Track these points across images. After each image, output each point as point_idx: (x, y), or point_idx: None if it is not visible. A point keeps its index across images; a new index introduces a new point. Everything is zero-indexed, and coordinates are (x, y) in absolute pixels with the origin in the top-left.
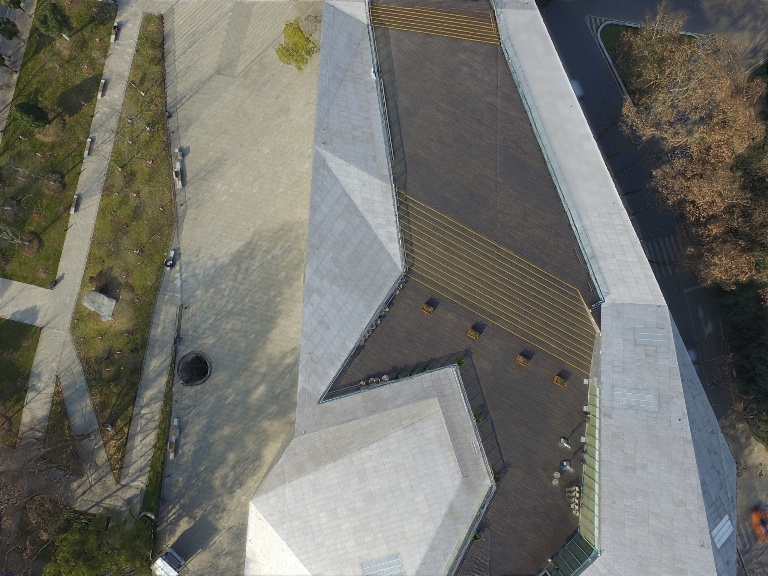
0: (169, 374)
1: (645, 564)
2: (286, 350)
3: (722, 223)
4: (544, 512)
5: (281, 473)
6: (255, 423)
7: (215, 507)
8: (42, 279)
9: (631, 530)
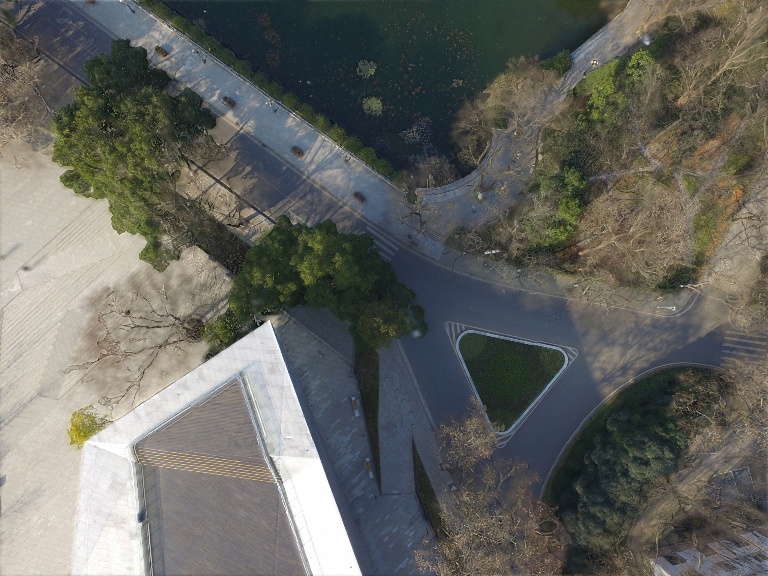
0: None
1: None
2: None
3: None
4: None
5: None
6: None
7: None
8: None
9: None
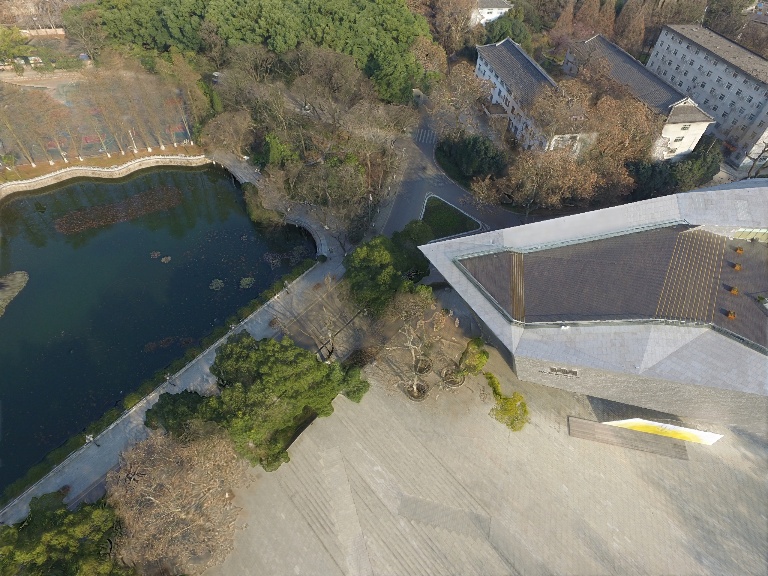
0: None
1: None
2: (761, 483)
3: None
4: None
5: None
6: None
7: None
8: None
9: None
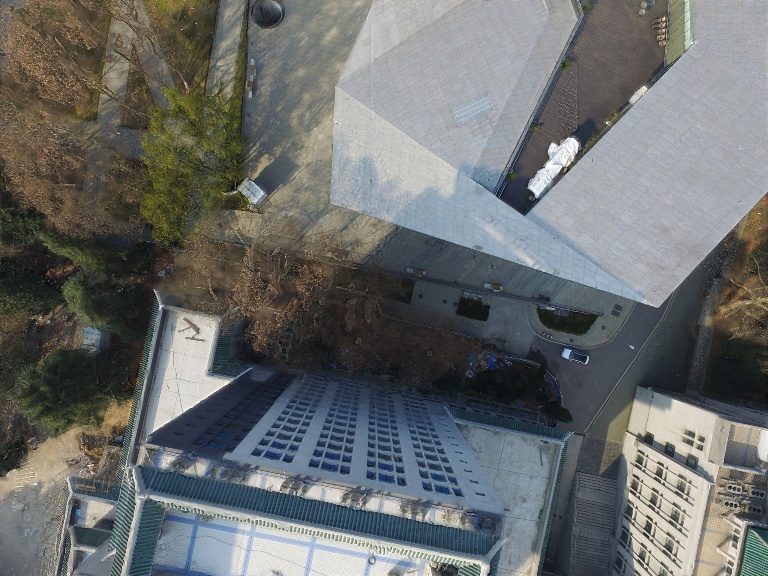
0: (242, 24)
1: (740, 40)
2: None
3: None
4: (630, 47)
5: (367, 41)
6: (329, 64)
7: (294, 144)
8: None
9: (724, 15)
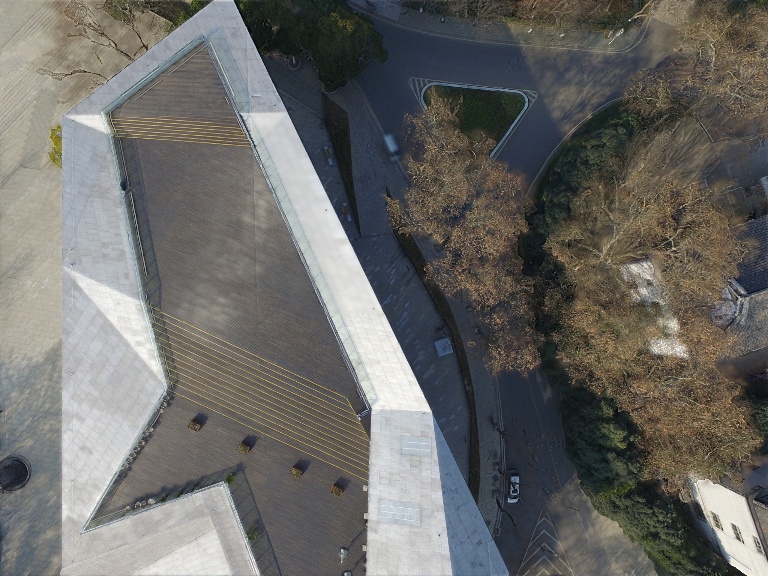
0: None
1: None
2: None
3: (510, 310)
4: None
5: None
6: None
7: None
8: None
9: None
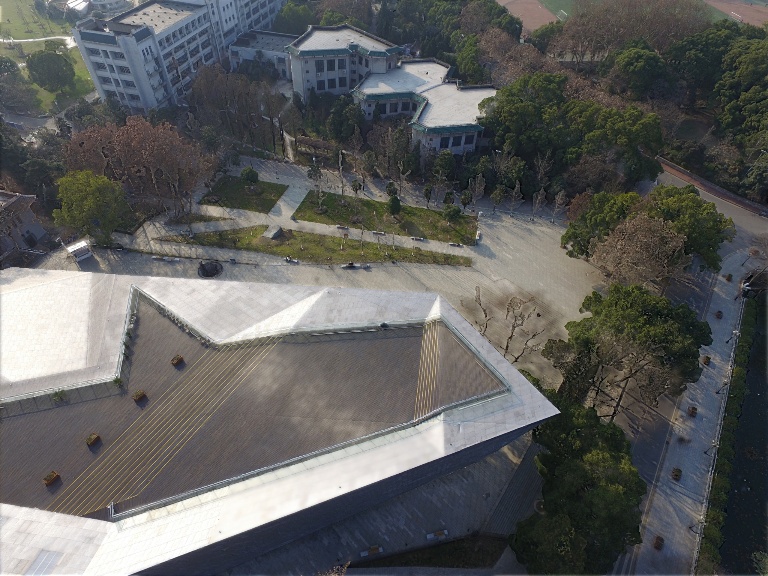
0: None
1: None
2: None
3: None
4: None
5: None
6: None
7: None
8: (298, 215)
9: None
